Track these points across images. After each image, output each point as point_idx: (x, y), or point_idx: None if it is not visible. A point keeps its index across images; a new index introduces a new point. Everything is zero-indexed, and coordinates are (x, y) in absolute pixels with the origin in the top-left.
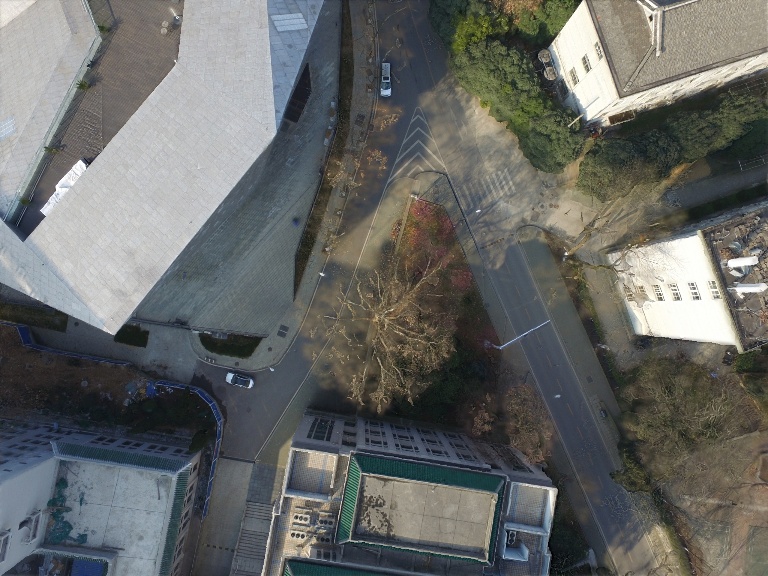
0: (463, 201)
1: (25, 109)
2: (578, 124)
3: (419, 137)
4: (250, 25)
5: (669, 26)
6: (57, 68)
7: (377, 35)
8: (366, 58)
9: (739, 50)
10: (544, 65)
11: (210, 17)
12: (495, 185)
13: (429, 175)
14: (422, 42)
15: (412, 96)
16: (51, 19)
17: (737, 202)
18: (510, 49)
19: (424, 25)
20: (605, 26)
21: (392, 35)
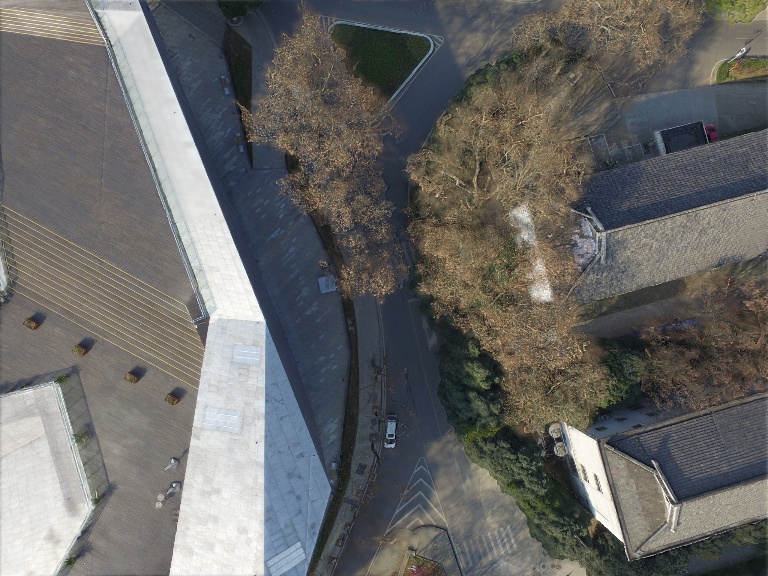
0: (462, 558)
1: (11, 575)
2: (585, 533)
3: (421, 488)
4: (245, 569)
5: (686, 509)
6: (46, 536)
7: (385, 383)
8: (372, 407)
9: (758, 512)
10: (555, 441)
11: (205, 540)
12: (496, 542)
13: (429, 530)
14: (430, 392)
15: (417, 446)
16: (45, 471)
17: (747, 573)
18: (520, 450)
19: (434, 377)
20: (619, 484)
21: (400, 384)
